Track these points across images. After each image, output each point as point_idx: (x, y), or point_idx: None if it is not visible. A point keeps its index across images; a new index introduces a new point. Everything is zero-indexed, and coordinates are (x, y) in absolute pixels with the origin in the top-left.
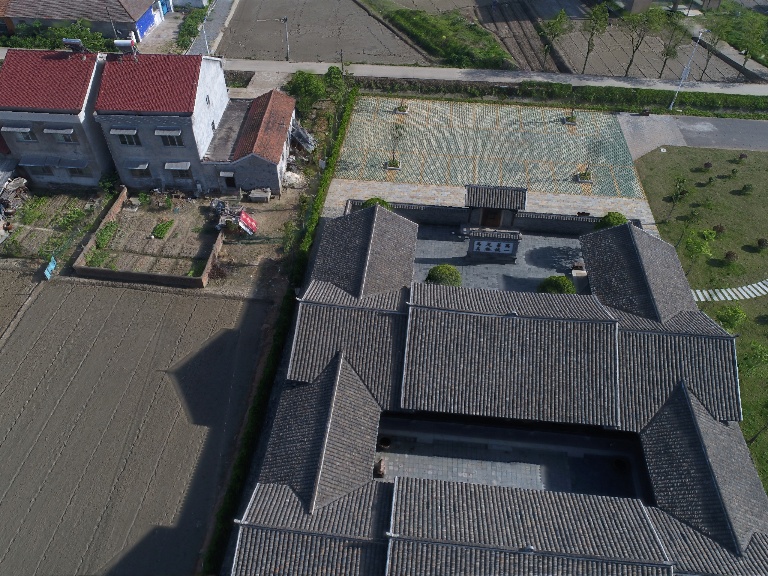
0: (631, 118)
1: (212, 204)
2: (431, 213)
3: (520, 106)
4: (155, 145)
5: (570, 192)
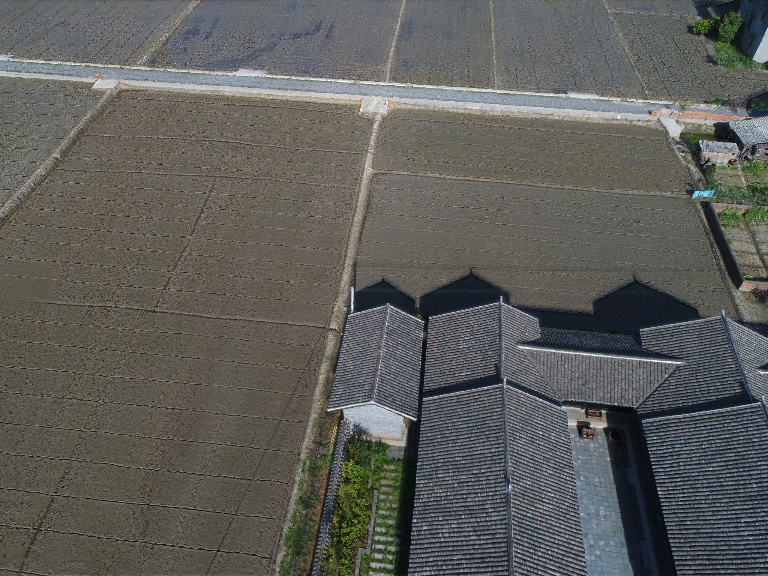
0: None
1: None
2: None
3: None
4: None
5: None
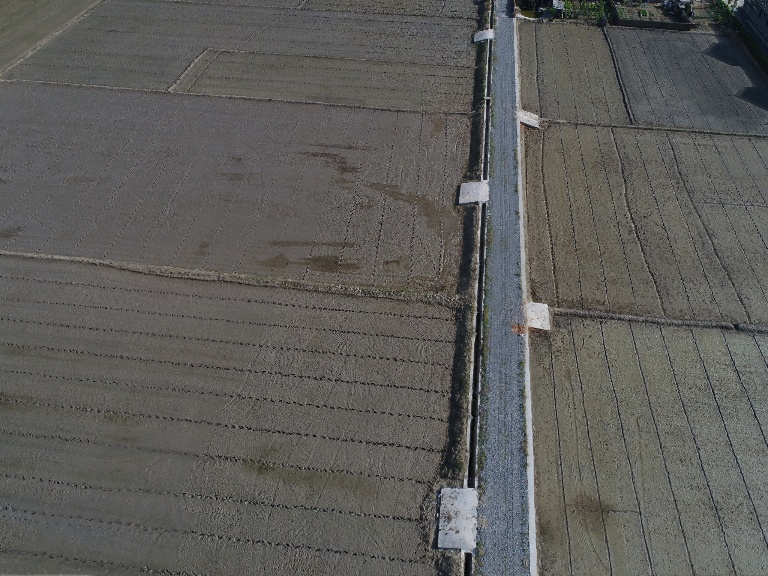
0: None
1: (665, 2)
2: None
3: None
4: None
5: None
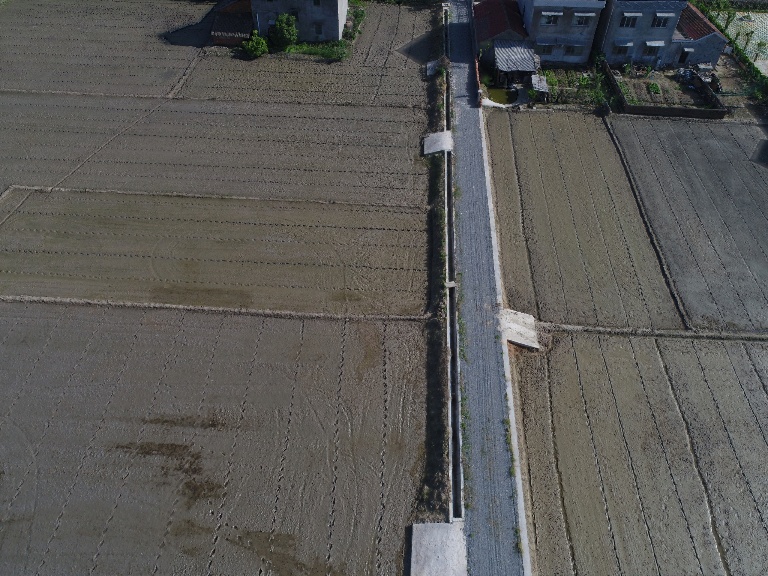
0: None
1: (680, 72)
2: None
3: None
4: (645, 27)
5: None
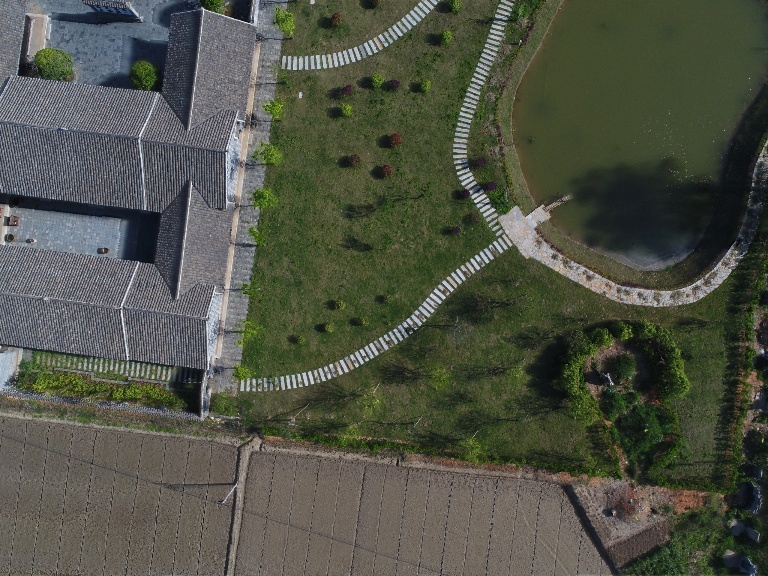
0: None
1: None
2: None
3: None
4: None
5: None
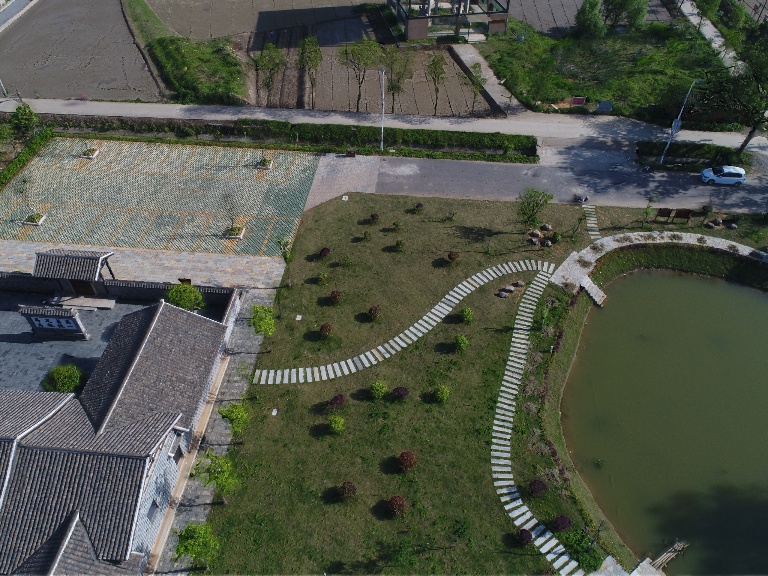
0: (334, 160)
1: None
2: (19, 281)
3: (222, 147)
4: None
5: (209, 250)
